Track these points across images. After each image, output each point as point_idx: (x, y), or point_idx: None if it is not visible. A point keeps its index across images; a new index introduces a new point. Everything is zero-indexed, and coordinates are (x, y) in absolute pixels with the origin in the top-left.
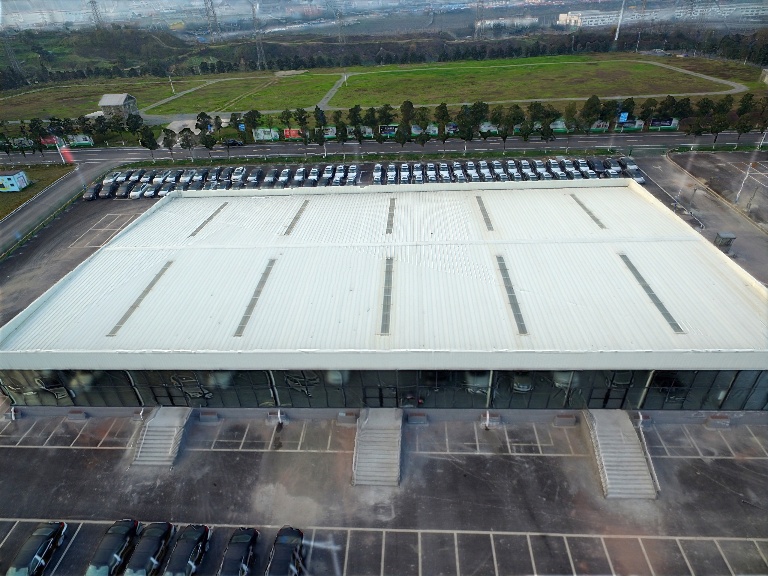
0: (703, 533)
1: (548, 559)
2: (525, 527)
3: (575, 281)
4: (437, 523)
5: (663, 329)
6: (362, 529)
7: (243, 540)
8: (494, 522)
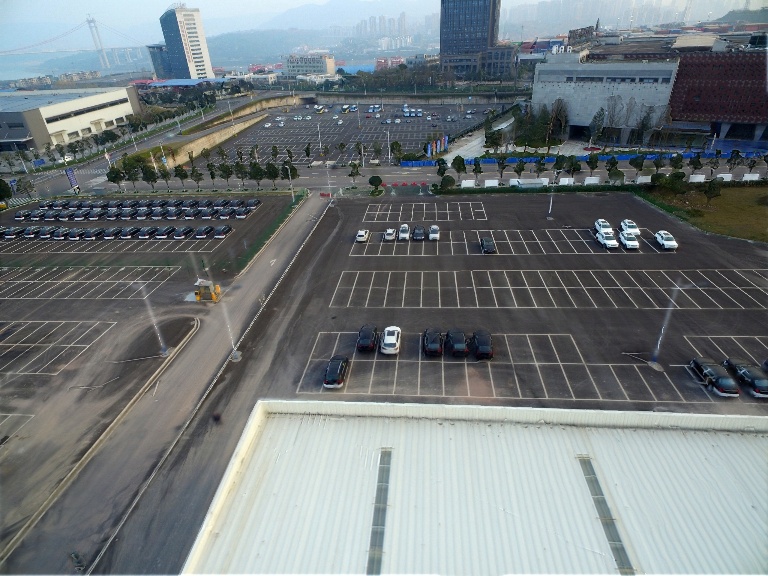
0: (424, 398)
1: (534, 387)
2: (550, 401)
3: (496, 574)
4: (618, 404)
5: (403, 456)
6: (675, 402)
7: (760, 383)
8: (573, 404)
